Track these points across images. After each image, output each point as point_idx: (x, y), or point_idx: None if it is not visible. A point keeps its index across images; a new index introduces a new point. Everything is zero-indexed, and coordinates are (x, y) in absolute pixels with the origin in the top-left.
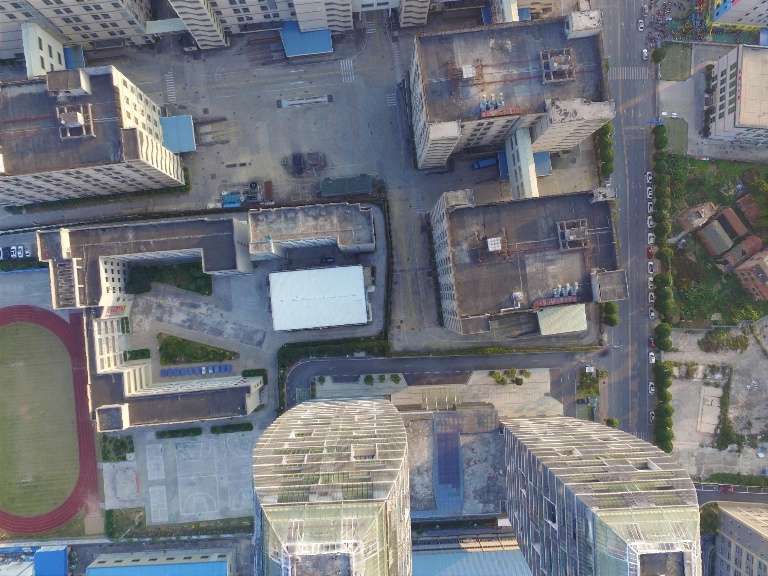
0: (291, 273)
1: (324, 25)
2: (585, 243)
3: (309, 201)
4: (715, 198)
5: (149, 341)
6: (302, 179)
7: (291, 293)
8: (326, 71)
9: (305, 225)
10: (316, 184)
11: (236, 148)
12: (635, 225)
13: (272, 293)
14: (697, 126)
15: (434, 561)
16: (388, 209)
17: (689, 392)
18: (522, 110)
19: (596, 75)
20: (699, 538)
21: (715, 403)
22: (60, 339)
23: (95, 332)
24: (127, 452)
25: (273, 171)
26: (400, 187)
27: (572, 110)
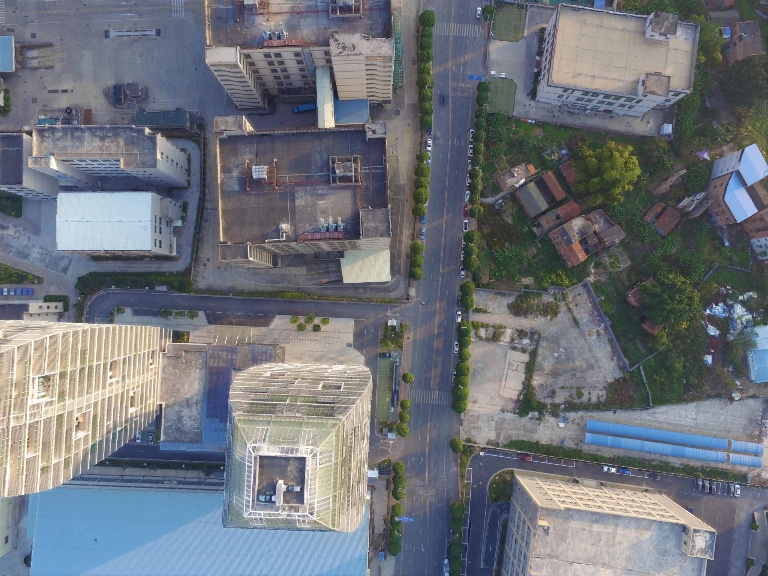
0: (79, 194)
1: None
2: (357, 180)
3: None
4: (538, 161)
5: None
6: (122, 110)
7: (77, 214)
8: (157, 5)
9: (91, 145)
10: None
11: (60, 74)
12: (454, 182)
13: (58, 212)
14: (526, 88)
15: (208, 500)
16: (205, 146)
17: (495, 355)
18: (305, 42)
19: (385, 14)
20: (335, 449)
21: (521, 368)
22: None
23: None
24: None
25: (94, 100)
26: None
27: (350, 44)
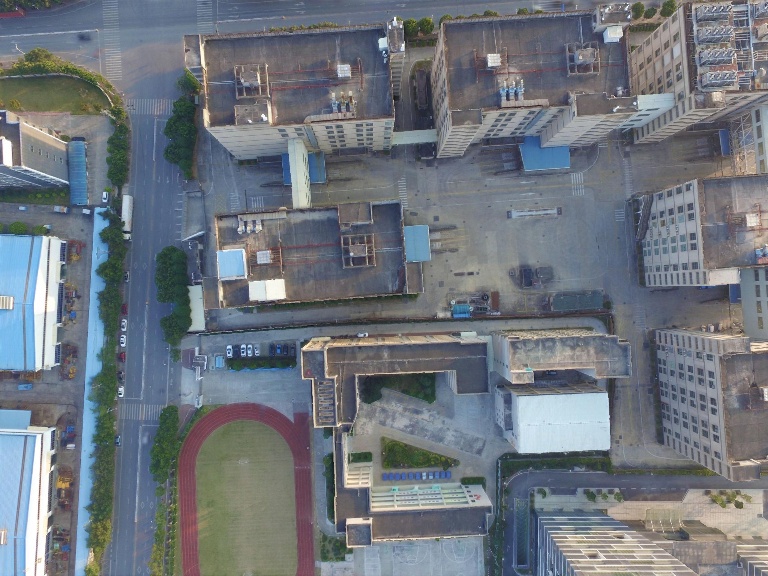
0: (539, 397)
1: (567, 143)
2: None
3: (535, 313)
4: None
5: (371, 444)
6: (528, 291)
7: (538, 417)
8: (557, 183)
9: (562, 354)
10: (542, 296)
11: (465, 257)
12: None
13: (520, 417)
14: None
15: None
16: (613, 325)
17: None
18: None
19: None
20: None
21: None
22: (284, 438)
23: (343, 446)
24: (346, 553)
25: (500, 281)
26: (625, 303)
27: None
